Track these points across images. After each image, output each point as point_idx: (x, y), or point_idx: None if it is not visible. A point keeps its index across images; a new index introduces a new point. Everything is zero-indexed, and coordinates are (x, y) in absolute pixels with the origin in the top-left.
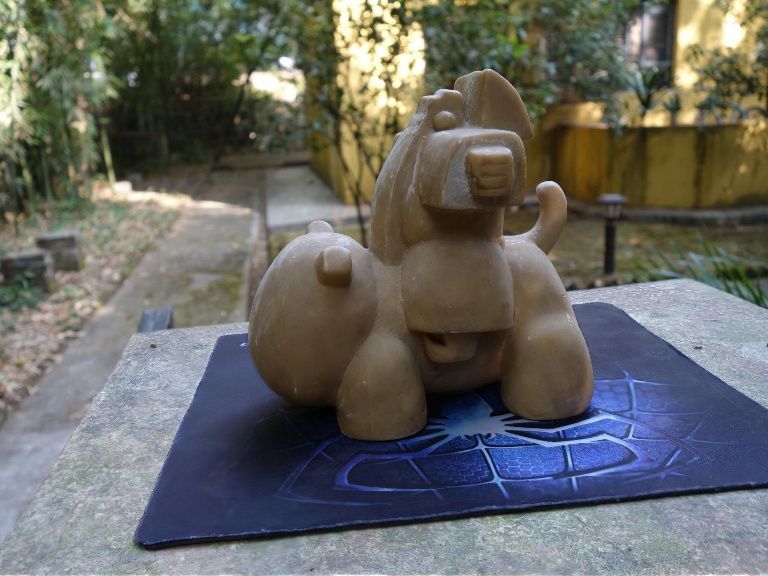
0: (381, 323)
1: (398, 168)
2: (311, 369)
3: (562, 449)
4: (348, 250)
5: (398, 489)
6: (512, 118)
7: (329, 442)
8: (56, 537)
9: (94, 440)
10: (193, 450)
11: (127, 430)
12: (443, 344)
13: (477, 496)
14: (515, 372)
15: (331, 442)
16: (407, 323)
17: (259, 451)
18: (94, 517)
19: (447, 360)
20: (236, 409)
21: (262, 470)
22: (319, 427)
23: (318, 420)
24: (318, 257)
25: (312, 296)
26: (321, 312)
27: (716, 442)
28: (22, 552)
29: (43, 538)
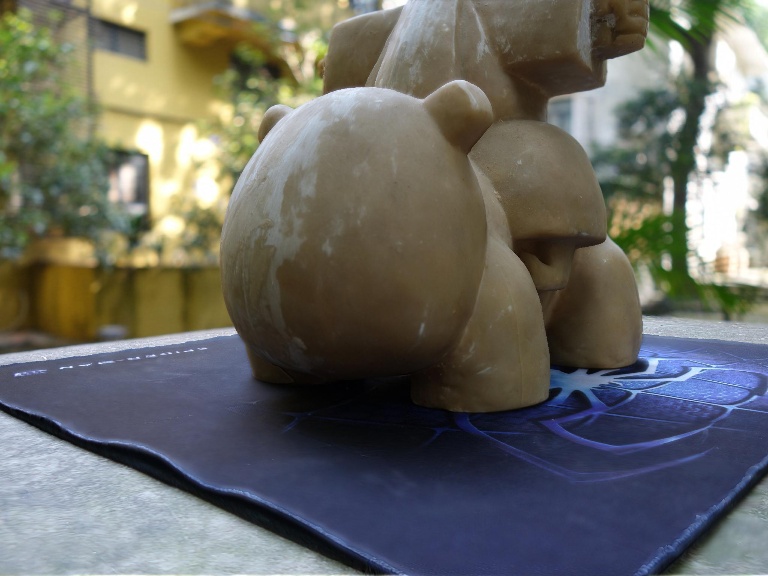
0: (492, 225)
1: (454, 20)
2: (452, 283)
3: (698, 379)
4: None
5: (680, 435)
6: None
7: (466, 422)
8: None
9: None
10: (264, 479)
11: None
12: (545, 263)
13: (759, 420)
14: (595, 306)
15: (469, 421)
16: (514, 228)
17: (393, 451)
18: None
19: (554, 285)
20: (203, 427)
21: (467, 465)
22: (406, 415)
23: (383, 410)
24: (437, 97)
25: (442, 157)
26: (457, 185)
27: (767, 358)
28: None
29: None
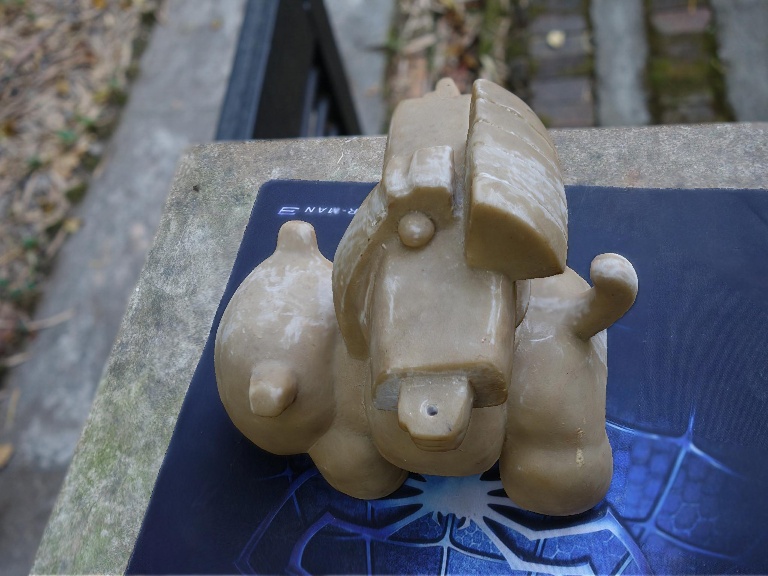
0: (341, 422)
1: (348, 279)
2: (269, 449)
3: None
4: (279, 390)
5: None
6: (522, 256)
7: (306, 478)
8: (72, 555)
9: (117, 394)
10: (188, 451)
11: (145, 383)
12: None
13: None
14: (503, 478)
15: (308, 478)
16: None
17: (241, 473)
18: (100, 536)
19: None
20: None
21: (235, 513)
22: None
23: None
24: None
25: None
26: (265, 422)
27: None
28: (48, 570)
29: (63, 554)
